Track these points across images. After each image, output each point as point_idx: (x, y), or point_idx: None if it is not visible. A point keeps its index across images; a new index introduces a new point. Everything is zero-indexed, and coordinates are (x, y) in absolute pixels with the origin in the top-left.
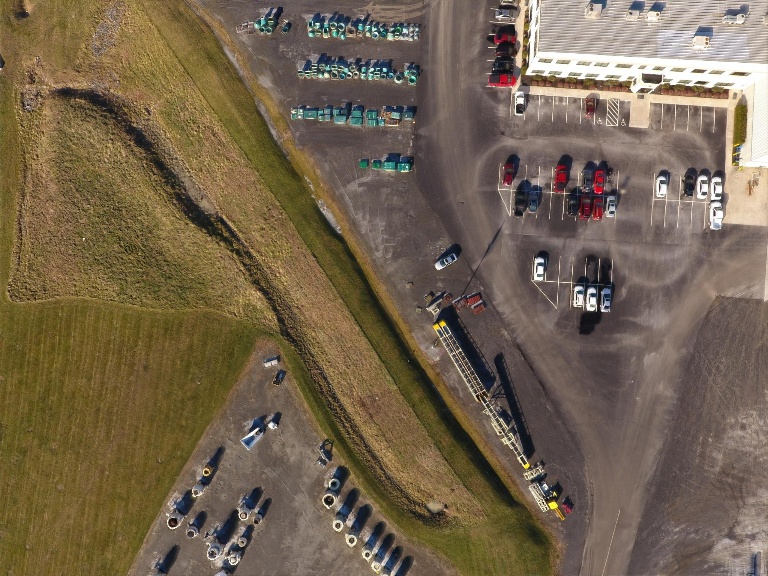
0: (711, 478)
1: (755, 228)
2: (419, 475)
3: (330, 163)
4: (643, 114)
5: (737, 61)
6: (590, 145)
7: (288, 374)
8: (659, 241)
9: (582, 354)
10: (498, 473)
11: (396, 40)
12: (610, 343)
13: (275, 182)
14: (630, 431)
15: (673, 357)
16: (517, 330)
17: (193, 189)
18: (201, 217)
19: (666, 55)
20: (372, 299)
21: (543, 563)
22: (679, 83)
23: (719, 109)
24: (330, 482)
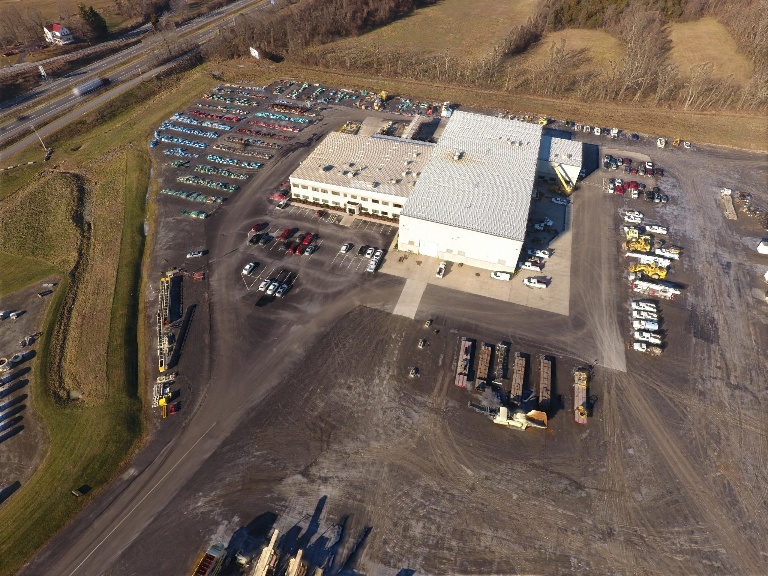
0: (307, 419)
1: (398, 277)
2: (82, 366)
3: (165, 209)
4: (349, 221)
5: (389, 194)
6: (313, 227)
7: (53, 293)
8: (333, 272)
9: (250, 316)
10: (139, 374)
11: (235, 178)
12: (273, 314)
13: (130, 210)
14: (257, 368)
15: (313, 331)
16: (215, 295)
17: (88, 211)
18: (80, 221)
19: (352, 187)
20: (137, 263)
21: (122, 448)
22: (374, 213)
23: (395, 227)
24: (15, 355)
